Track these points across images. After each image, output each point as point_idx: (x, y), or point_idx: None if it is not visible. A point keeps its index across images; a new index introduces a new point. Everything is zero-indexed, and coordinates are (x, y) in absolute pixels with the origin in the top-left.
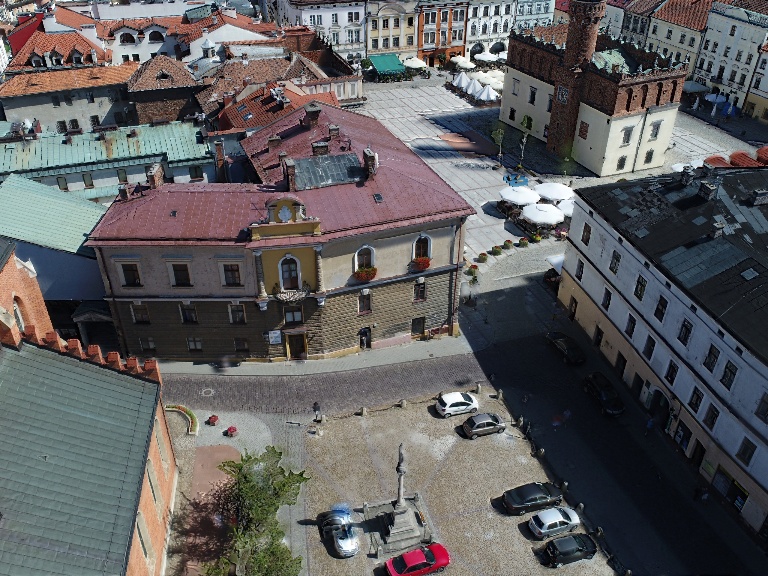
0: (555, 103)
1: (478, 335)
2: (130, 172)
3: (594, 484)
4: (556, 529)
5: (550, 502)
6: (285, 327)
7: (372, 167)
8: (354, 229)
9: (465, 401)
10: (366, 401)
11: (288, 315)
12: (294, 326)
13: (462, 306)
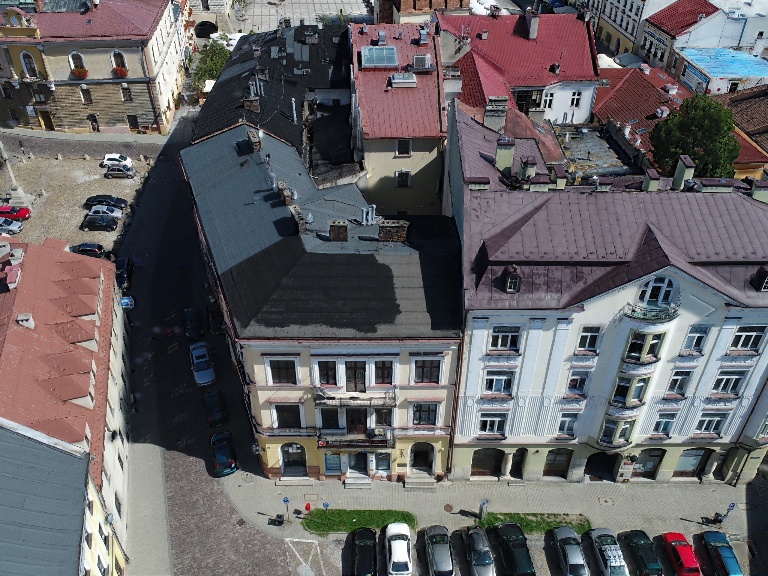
0: (379, 4)
1: (179, 136)
2: (0, 9)
3: (156, 207)
4: (100, 215)
5: (111, 205)
6: (35, 104)
7: (89, 2)
8: (63, 38)
9: (118, 158)
10: (69, 154)
11: (37, 96)
12: (41, 104)
13: (189, 122)
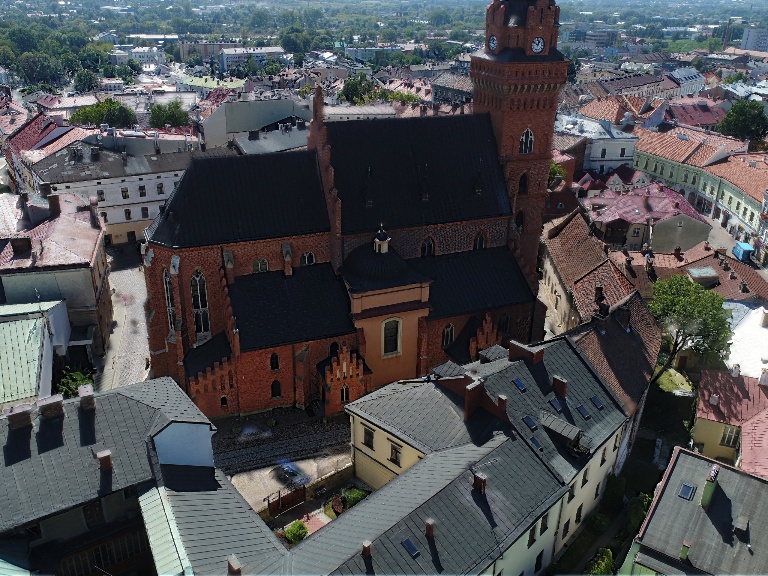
0: None
1: None
2: None
3: None
4: None
5: None
6: None
7: (52, 189)
8: None
9: None
10: None
11: None
12: None
13: None
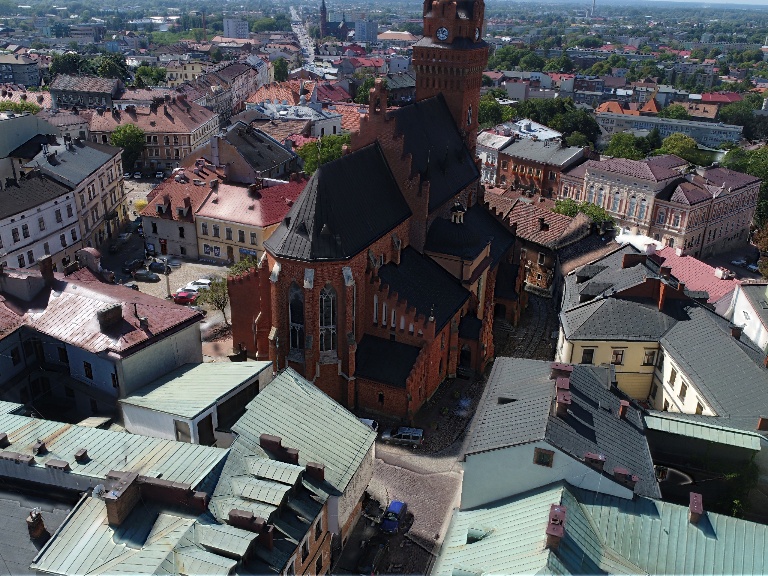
0: None
1: None
2: None
3: None
4: None
5: None
6: None
7: None
8: None
9: None
10: None
11: None
12: None
13: None
